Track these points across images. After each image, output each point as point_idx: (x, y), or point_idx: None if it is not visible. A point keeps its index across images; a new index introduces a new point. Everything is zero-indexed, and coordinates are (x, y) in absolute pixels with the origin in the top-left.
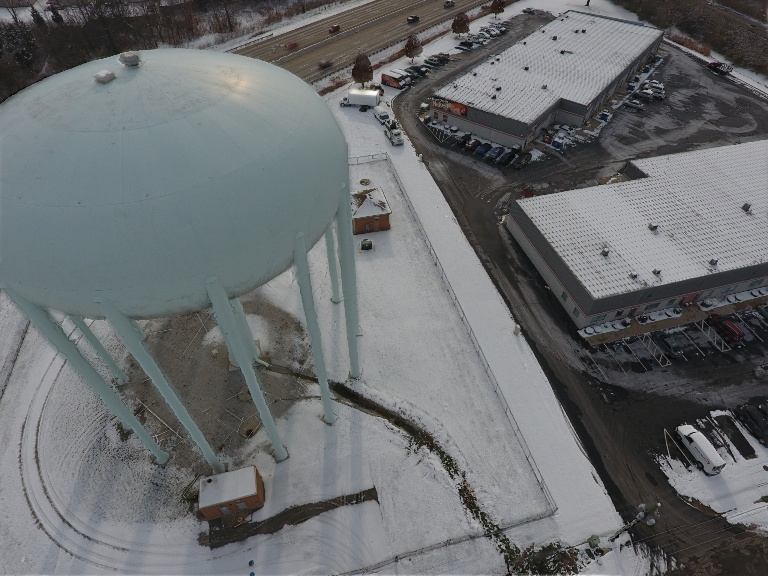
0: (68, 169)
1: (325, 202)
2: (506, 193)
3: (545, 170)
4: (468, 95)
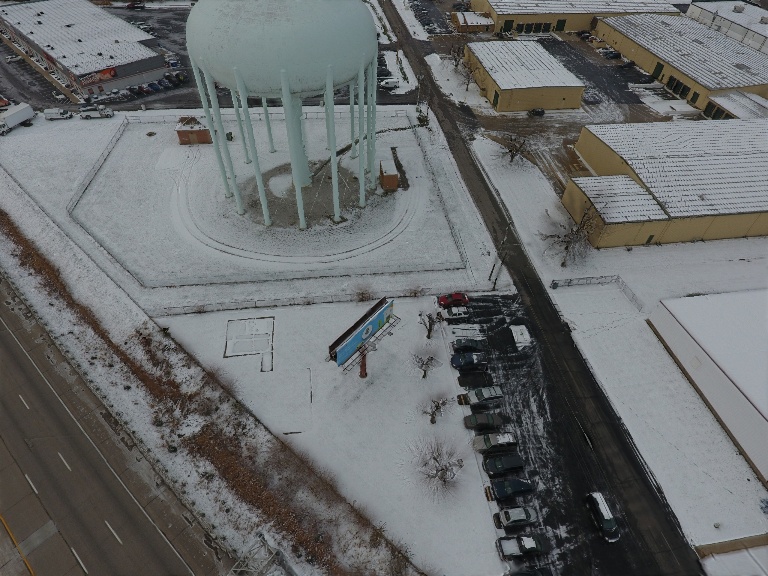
0: None
1: None
2: None
3: None
4: (96, 65)
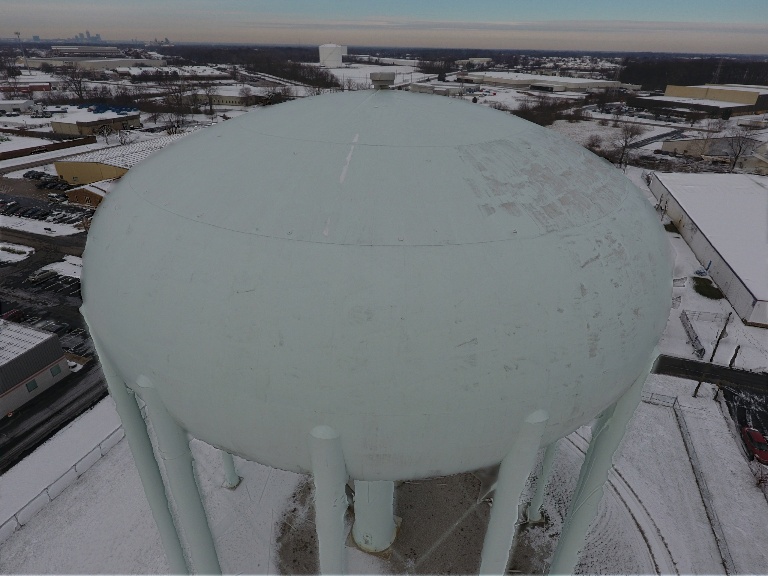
0: None
1: None
2: None
3: None
4: None
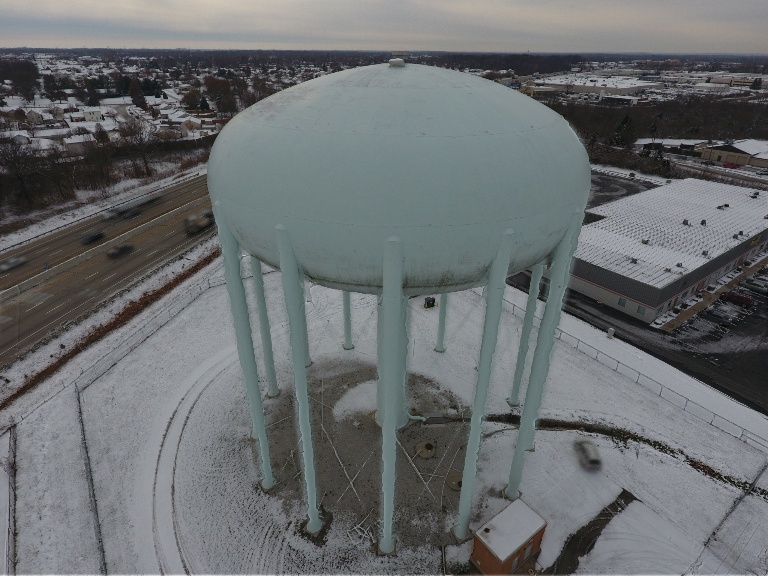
0: (452, 110)
1: None
2: None
3: None
4: None
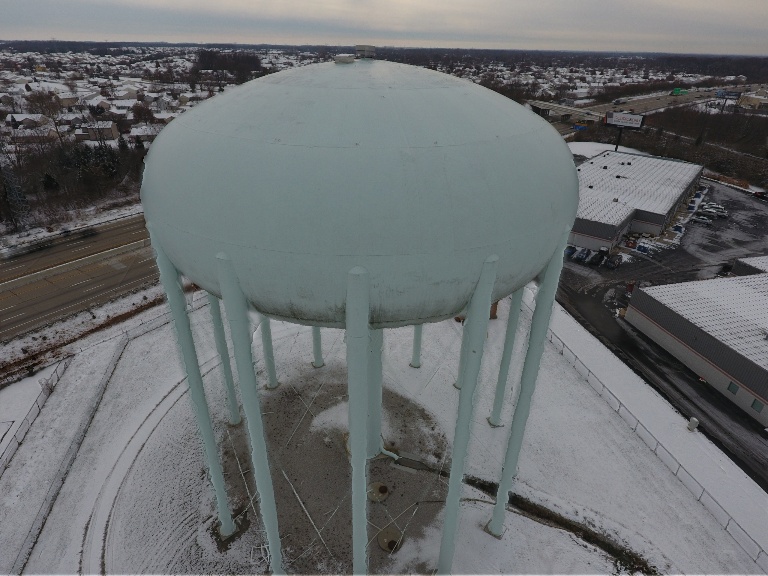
0: (336, 115)
1: None
2: (609, 289)
3: (640, 270)
4: None
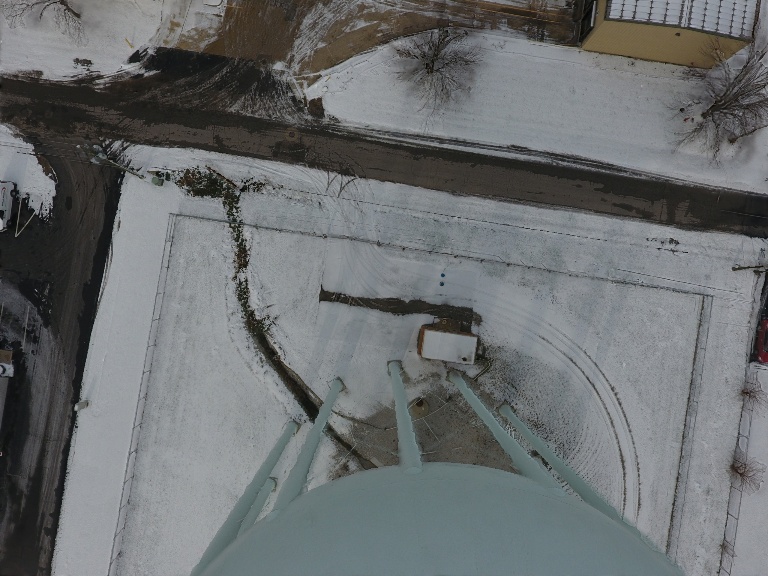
0: None
1: (208, 573)
2: None
3: None
4: None
